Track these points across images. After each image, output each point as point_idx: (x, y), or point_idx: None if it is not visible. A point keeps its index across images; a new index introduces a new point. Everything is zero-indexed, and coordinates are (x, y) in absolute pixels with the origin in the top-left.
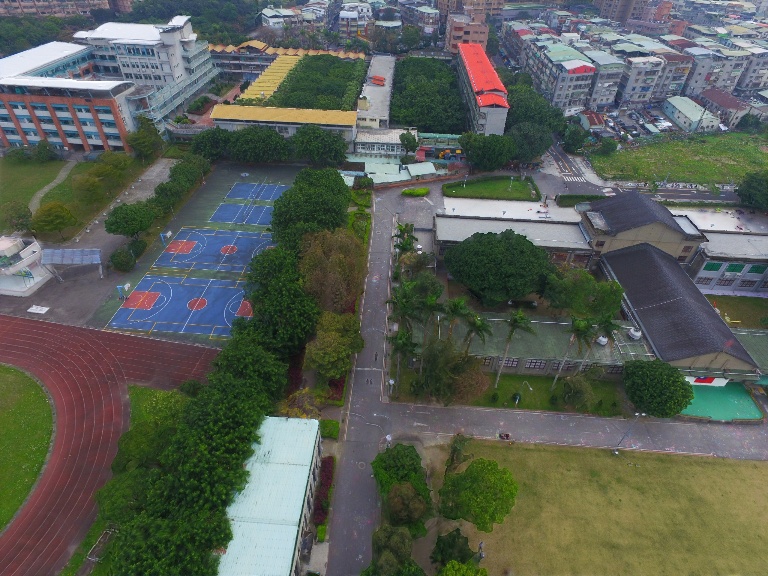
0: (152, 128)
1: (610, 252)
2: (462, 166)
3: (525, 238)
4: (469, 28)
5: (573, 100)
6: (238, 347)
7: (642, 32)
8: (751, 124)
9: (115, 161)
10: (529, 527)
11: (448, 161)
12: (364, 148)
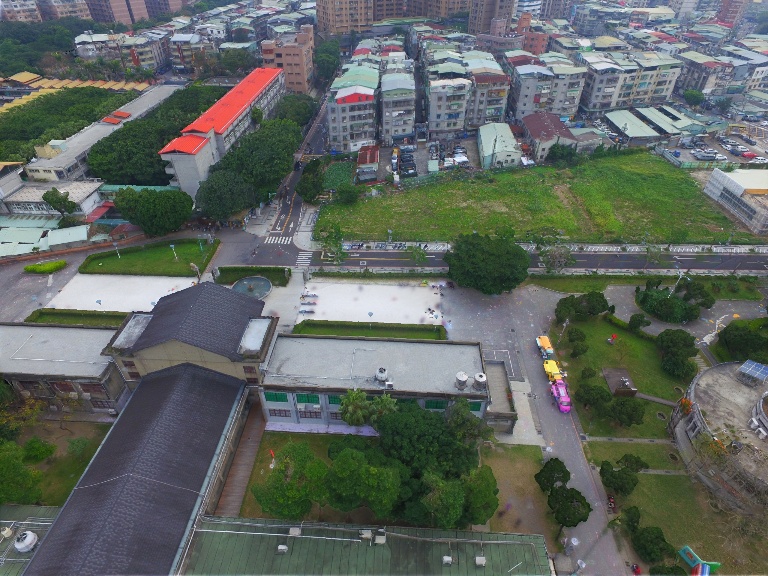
0: None
1: (150, 374)
2: (128, 229)
3: None
4: (280, 50)
5: (355, 133)
6: None
7: (492, 48)
8: (563, 156)
9: None
10: None
11: (121, 221)
12: (20, 208)
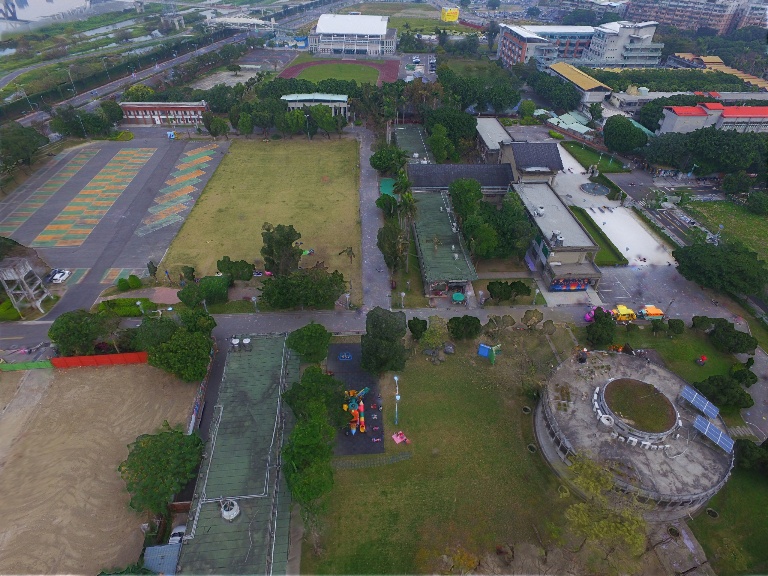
0: (534, 66)
1: None
2: (603, 139)
3: (470, 120)
4: None
5: None
6: (371, 86)
7: None
8: None
9: None
10: (325, 149)
11: None
12: (586, 110)
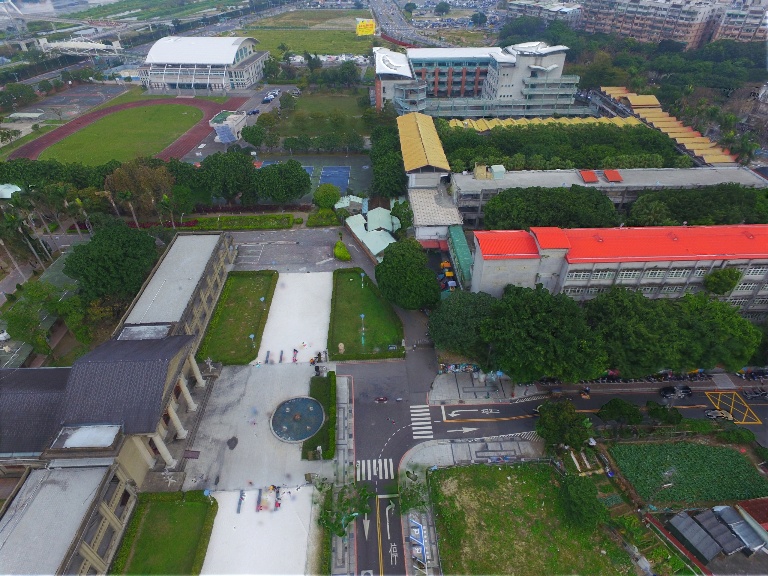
0: (392, 112)
1: None
2: None
3: None
4: None
5: None
6: None
7: None
8: None
9: None
10: None
11: None
12: None
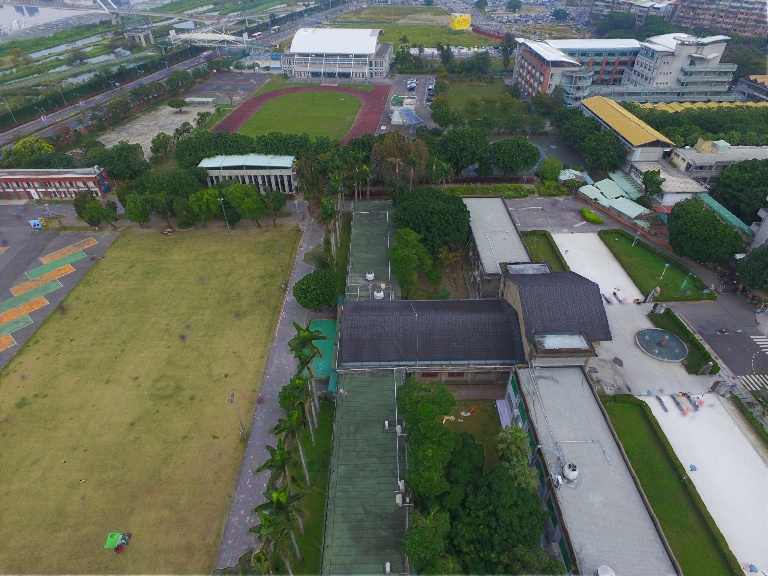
0: (560, 97)
1: None
2: (666, 232)
3: None
4: None
5: None
6: None
7: None
8: None
9: (505, 100)
10: (247, 249)
11: None
12: (635, 174)
